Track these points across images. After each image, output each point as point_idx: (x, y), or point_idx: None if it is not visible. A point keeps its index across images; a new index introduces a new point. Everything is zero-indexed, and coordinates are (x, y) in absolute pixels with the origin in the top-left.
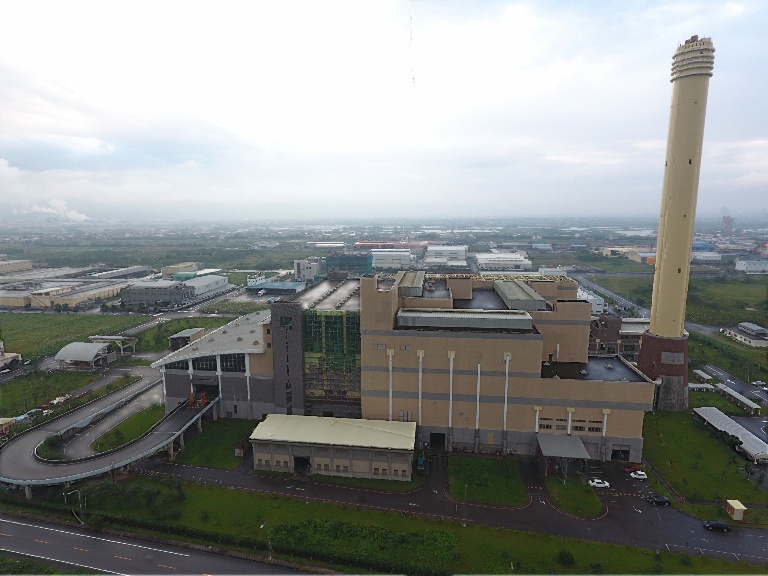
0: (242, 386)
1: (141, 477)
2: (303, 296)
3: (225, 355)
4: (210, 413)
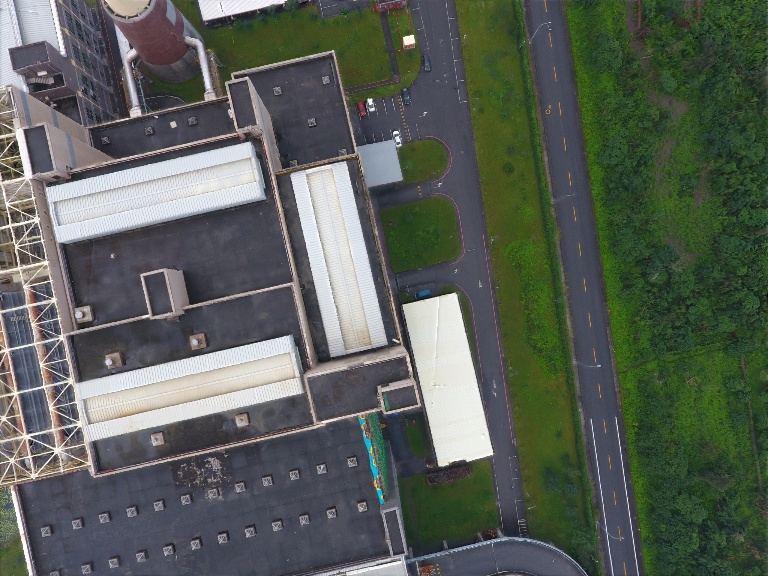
0: None
1: (532, 533)
2: (254, 575)
3: None
4: None
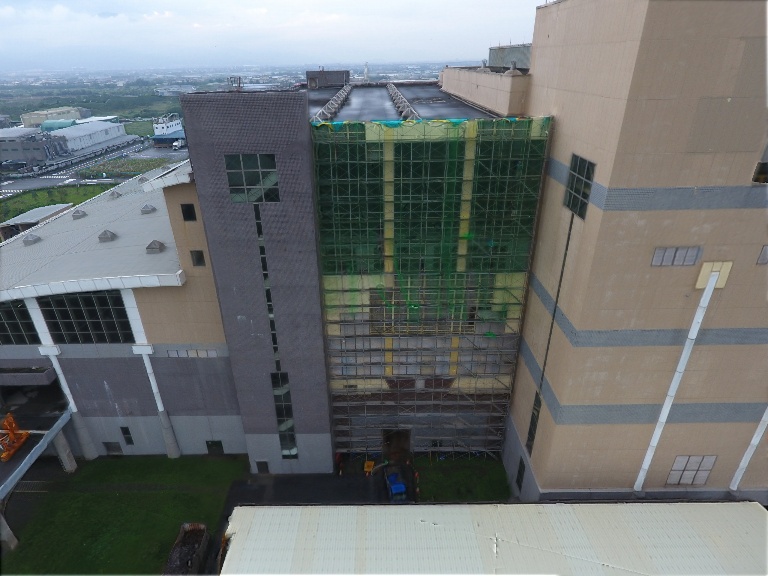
0: (132, 379)
1: None
2: None
3: (53, 297)
4: (50, 457)
